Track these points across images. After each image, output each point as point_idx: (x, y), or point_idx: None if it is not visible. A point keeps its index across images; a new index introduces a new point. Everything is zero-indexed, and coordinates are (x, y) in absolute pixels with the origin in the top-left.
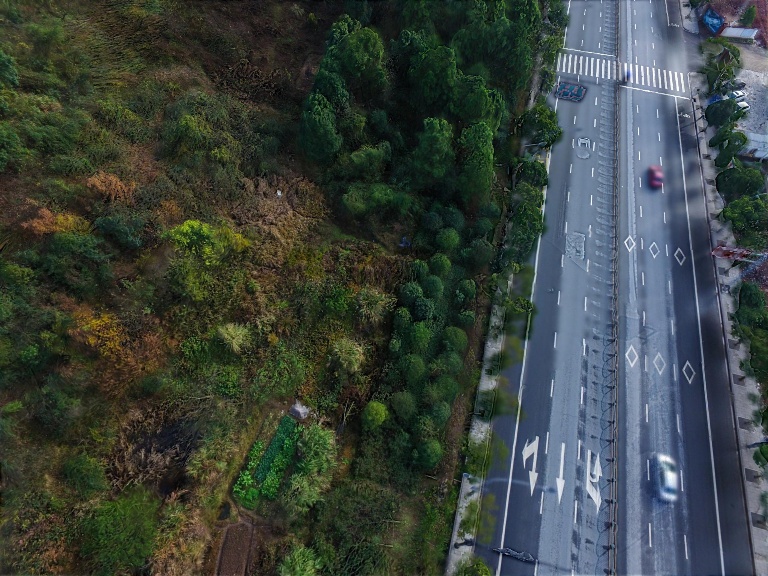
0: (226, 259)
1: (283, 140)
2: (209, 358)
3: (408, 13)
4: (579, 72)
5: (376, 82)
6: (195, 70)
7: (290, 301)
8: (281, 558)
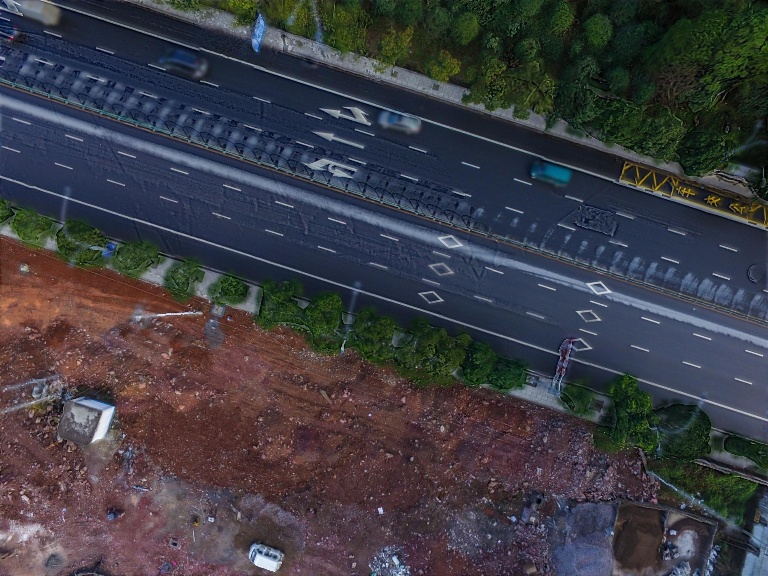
0: None
1: None
2: None
3: None
4: None
5: None
6: None
7: None
8: None
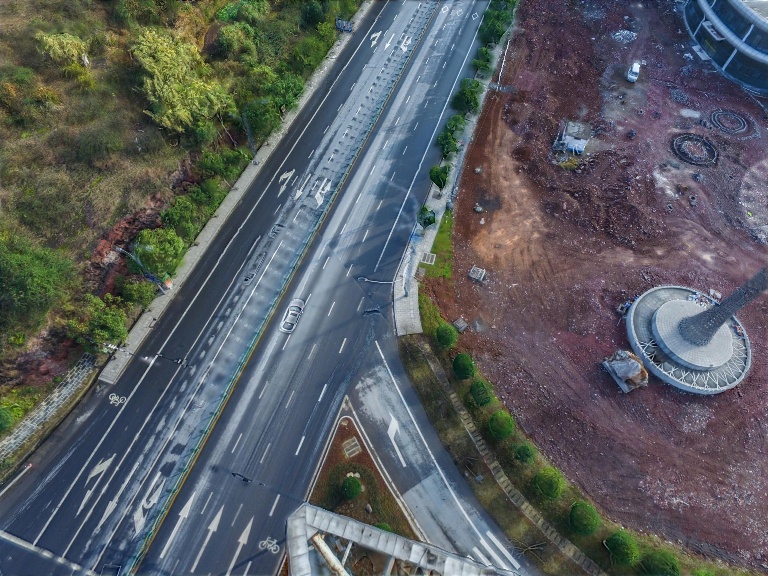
0: None
1: None
2: None
3: None
4: None
5: None
6: None
7: None
8: None
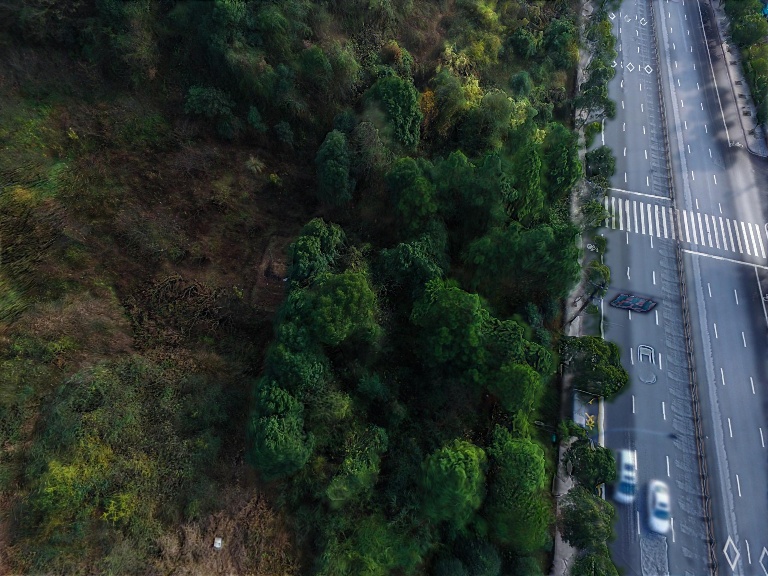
0: None
1: (227, 430)
2: None
3: (407, 208)
4: (627, 227)
5: (363, 341)
6: (101, 299)
7: None
8: None
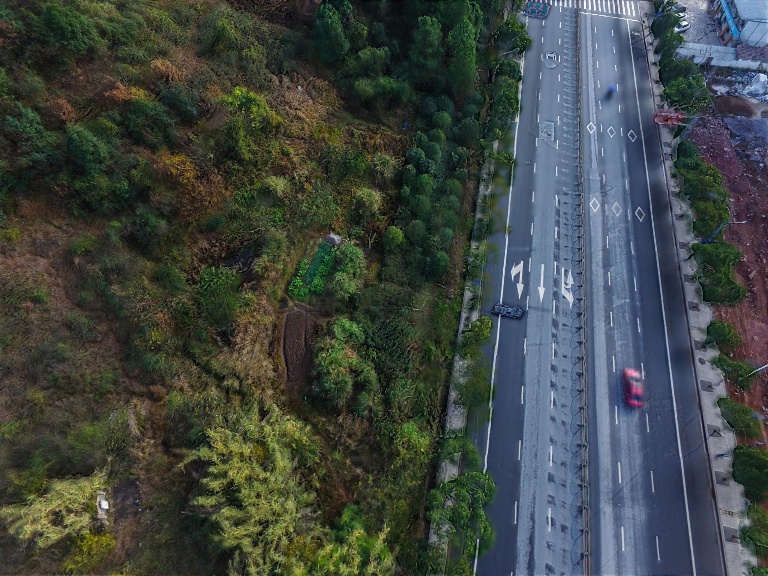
0: (264, 130)
1: (298, 49)
2: (258, 203)
3: None
4: None
5: None
6: None
7: (318, 162)
8: (332, 324)
